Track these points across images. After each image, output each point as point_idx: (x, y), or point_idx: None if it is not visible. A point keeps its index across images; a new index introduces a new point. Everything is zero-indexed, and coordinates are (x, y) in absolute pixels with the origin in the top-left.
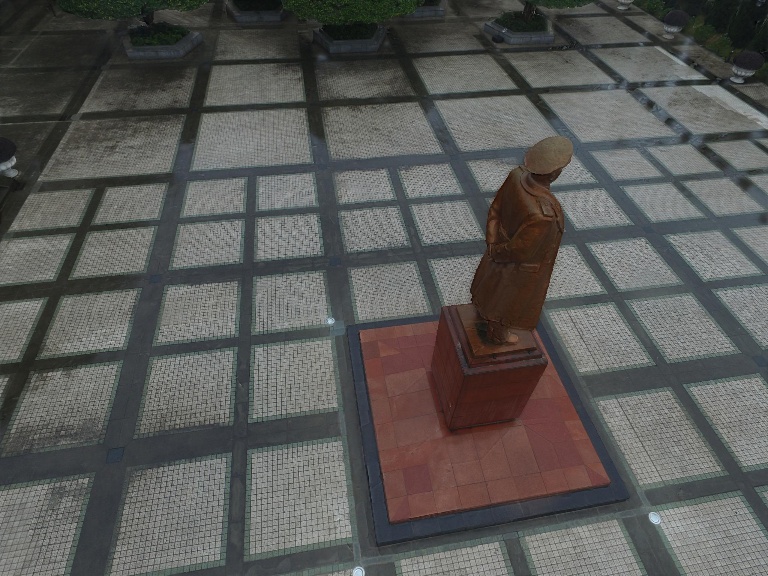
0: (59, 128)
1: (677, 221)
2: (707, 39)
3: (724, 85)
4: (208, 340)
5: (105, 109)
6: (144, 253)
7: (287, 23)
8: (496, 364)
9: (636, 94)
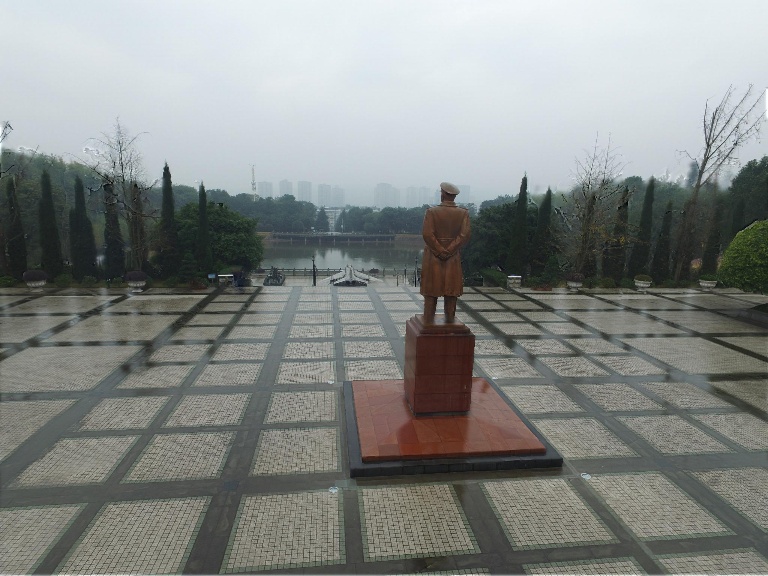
0: None
1: (276, 332)
2: (69, 284)
3: (138, 294)
4: None
5: None
6: None
7: None
8: None
9: (108, 314)
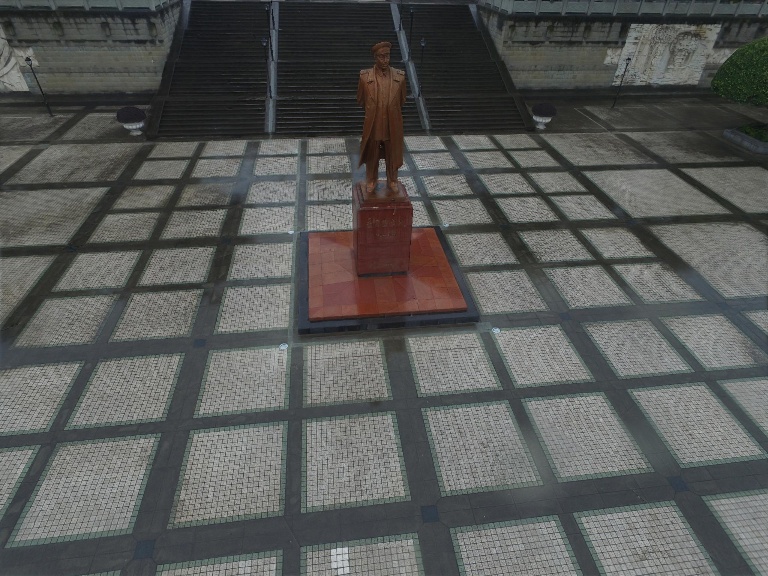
0: (598, 130)
1: (735, 546)
2: None
3: None
4: (425, 189)
5: (635, 138)
6: (489, 166)
7: None
8: None
9: None
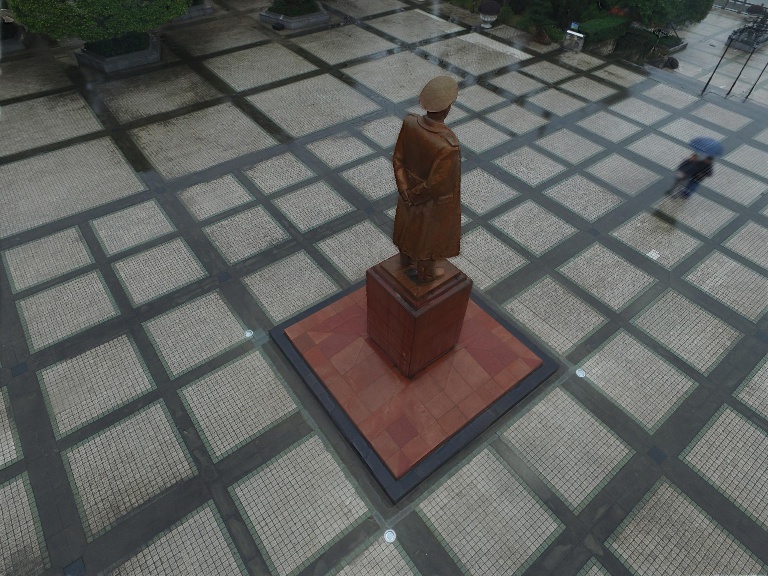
0: None
1: (495, 147)
2: None
3: (479, 32)
4: (123, 405)
5: None
6: None
7: (35, 50)
8: (435, 298)
9: (419, 52)
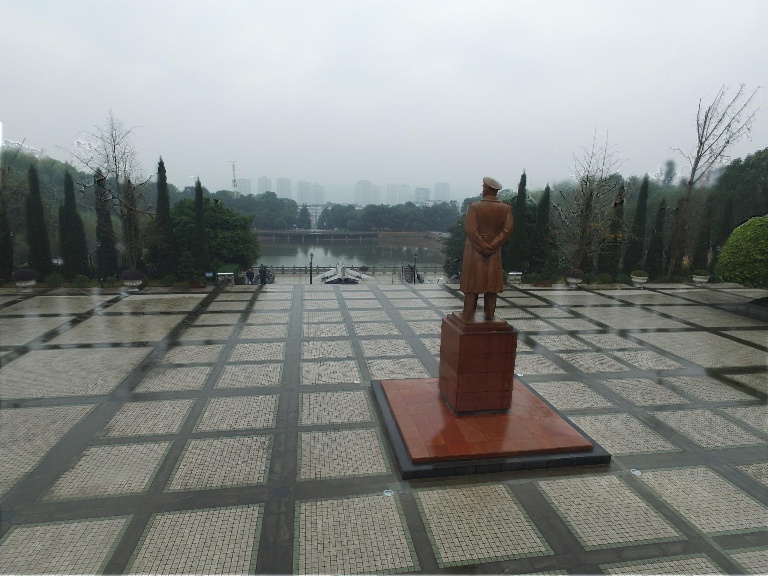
0: None
1: (289, 331)
2: (60, 283)
3: (135, 294)
4: None
5: None
6: None
7: None
8: None
9: (108, 314)
